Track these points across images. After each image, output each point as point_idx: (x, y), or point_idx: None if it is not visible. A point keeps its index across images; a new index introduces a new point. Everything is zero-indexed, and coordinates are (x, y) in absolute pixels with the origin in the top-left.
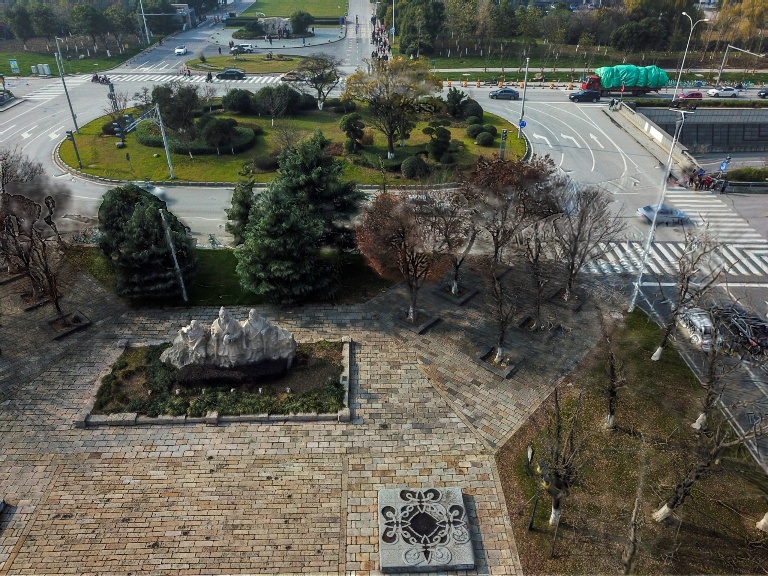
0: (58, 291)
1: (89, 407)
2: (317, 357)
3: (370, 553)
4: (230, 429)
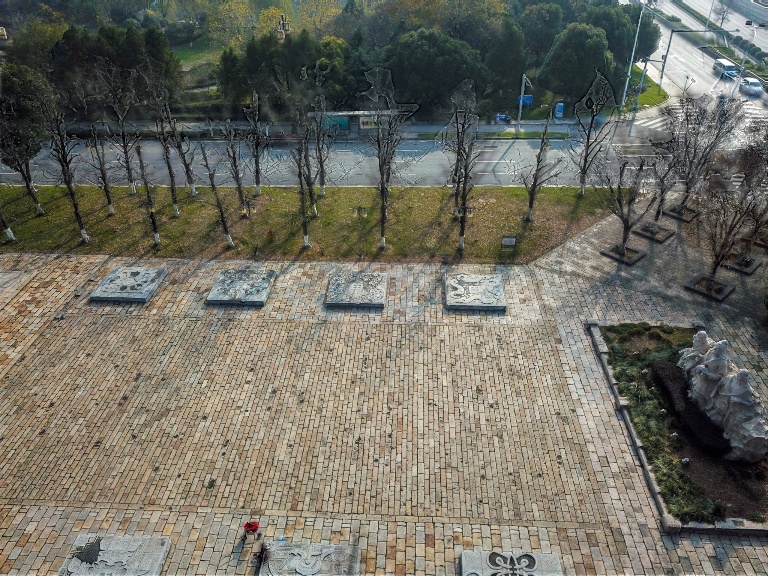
0: (756, 270)
1: (606, 323)
2: (767, 491)
3: (482, 546)
4: (615, 421)
